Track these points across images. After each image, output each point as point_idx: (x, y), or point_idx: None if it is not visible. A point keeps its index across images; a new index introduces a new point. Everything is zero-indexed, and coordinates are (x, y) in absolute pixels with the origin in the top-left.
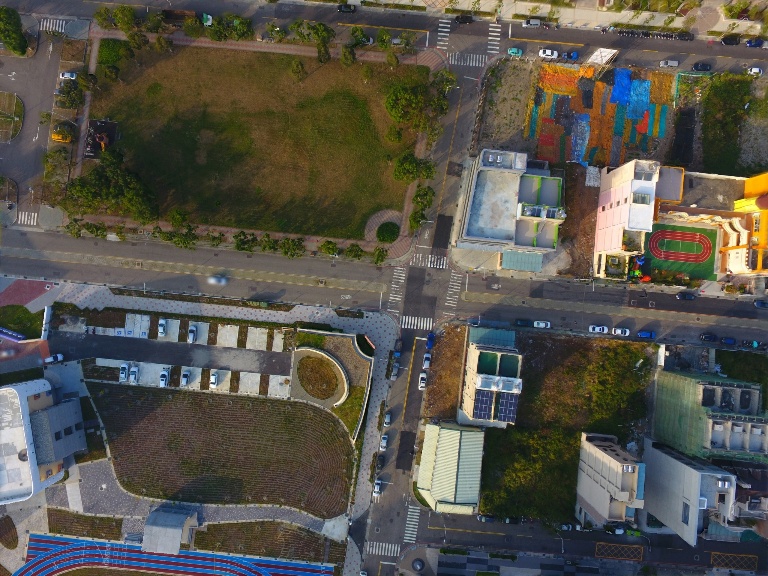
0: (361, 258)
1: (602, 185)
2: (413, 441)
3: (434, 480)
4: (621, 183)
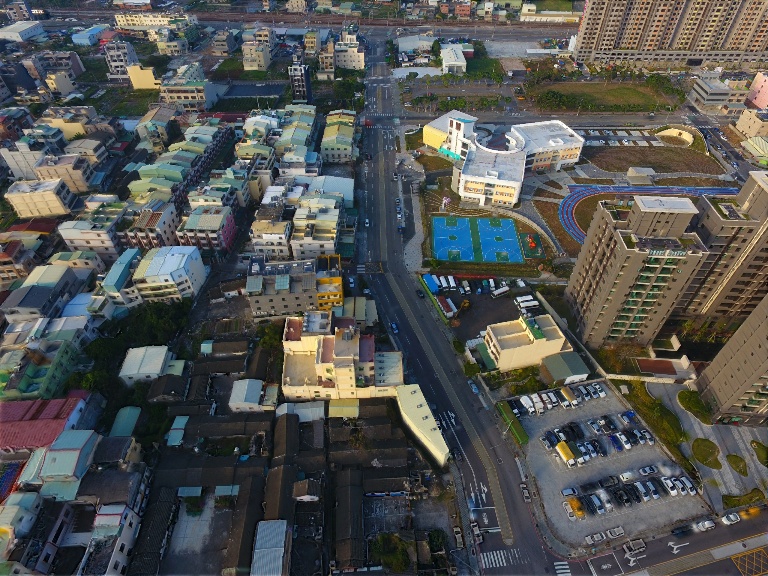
0: (664, 115)
1: (748, 96)
2: (737, 153)
3: (762, 149)
4: (758, 82)
